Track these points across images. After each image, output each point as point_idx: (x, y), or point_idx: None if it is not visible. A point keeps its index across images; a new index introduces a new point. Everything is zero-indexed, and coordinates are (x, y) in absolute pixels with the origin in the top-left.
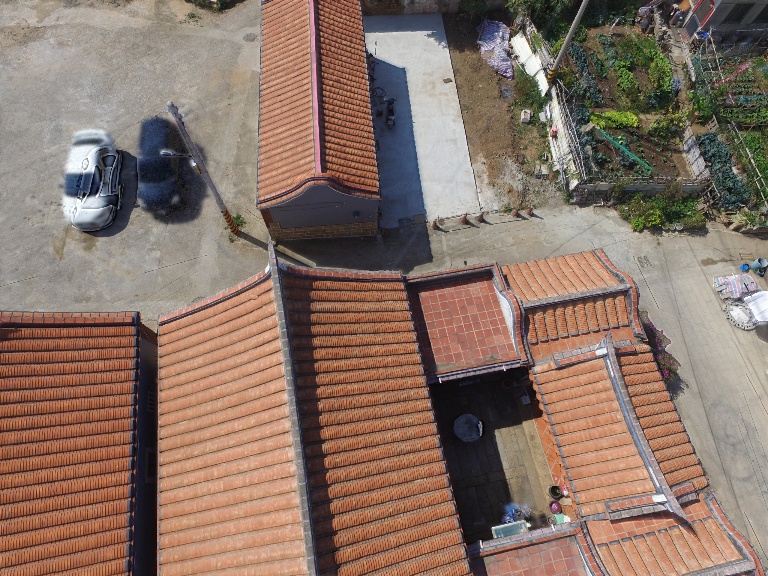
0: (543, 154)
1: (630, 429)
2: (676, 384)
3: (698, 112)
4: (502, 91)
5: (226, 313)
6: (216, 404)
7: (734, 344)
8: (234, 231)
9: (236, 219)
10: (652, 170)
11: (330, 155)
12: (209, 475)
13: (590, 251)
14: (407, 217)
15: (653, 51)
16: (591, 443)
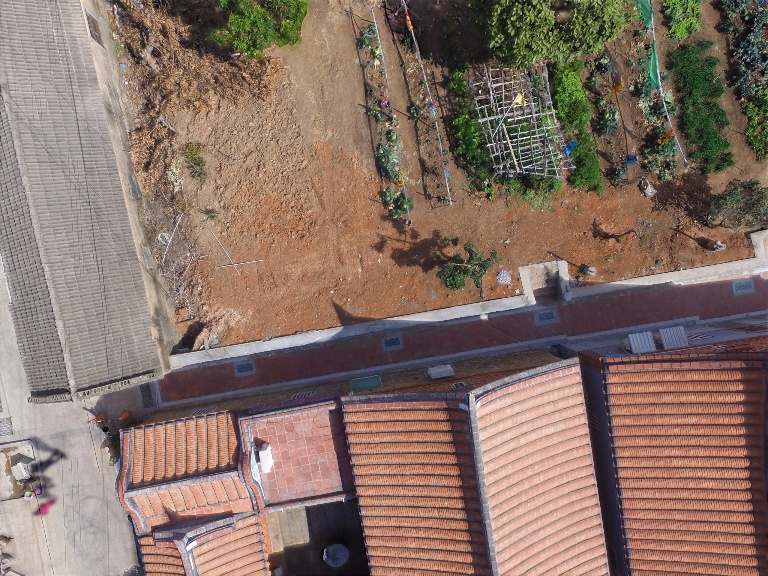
0: None
1: None
2: None
3: None
4: None
5: None
6: None
7: None
8: None
9: None
10: None
11: None
12: (569, 575)
13: None
14: None
15: None
16: None
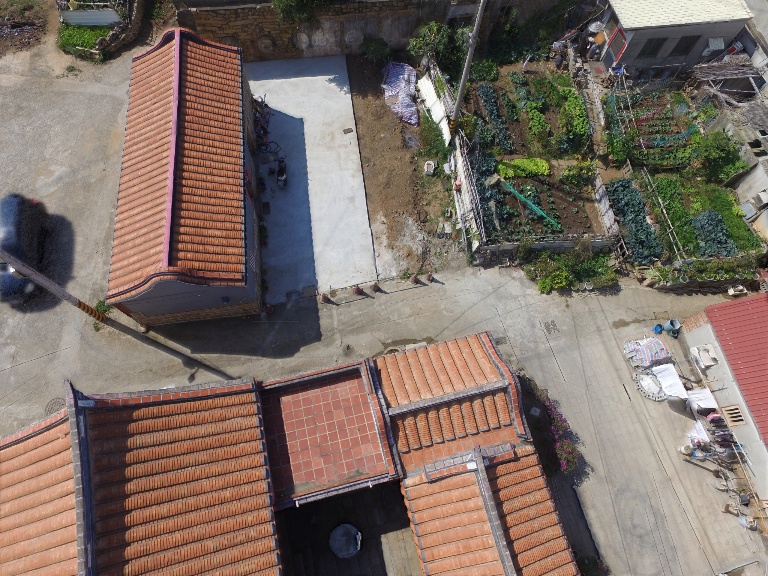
0: (446, 210)
1: (501, 557)
2: (581, 468)
3: (612, 156)
4: (406, 140)
5: (35, 452)
6: (17, 565)
7: (644, 418)
8: (98, 319)
9: (103, 304)
10: (563, 222)
11: (185, 242)
12: None
13: (475, 335)
14: (296, 290)
15: (567, 90)
16: (461, 572)
